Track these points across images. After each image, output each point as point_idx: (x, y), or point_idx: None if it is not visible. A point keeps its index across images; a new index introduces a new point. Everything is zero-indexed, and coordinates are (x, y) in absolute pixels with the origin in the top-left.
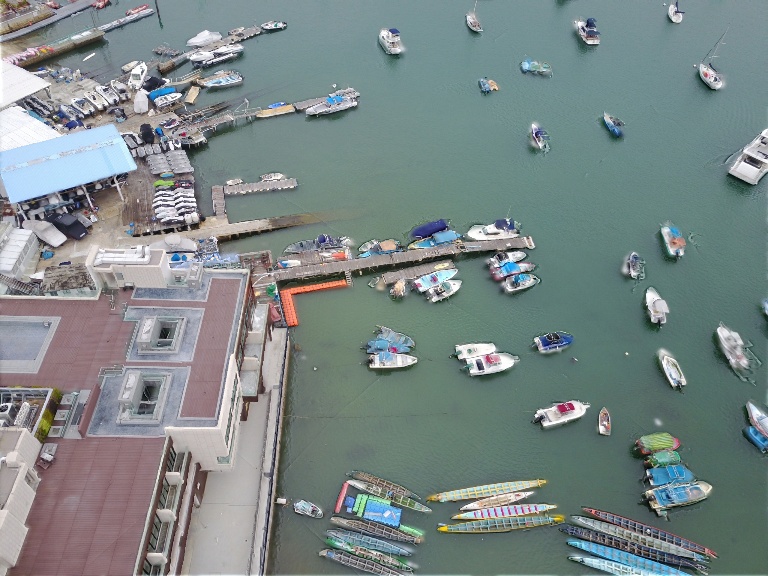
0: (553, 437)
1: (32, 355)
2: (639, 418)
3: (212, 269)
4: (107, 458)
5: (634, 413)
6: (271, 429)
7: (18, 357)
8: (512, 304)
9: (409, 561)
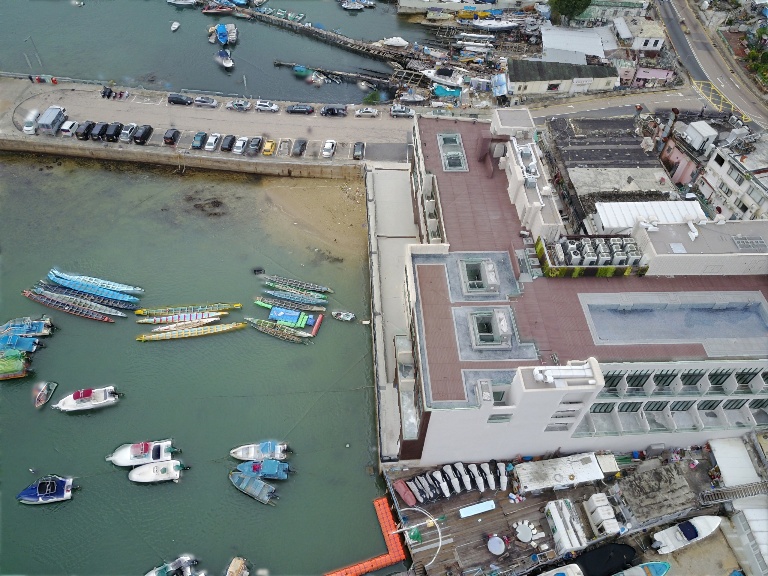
0: (109, 381)
1: (597, 318)
2: (2, 406)
3: (470, 409)
4: (485, 239)
5: (4, 410)
6: (381, 348)
7: (608, 316)
8: (71, 569)
9: (267, 288)
